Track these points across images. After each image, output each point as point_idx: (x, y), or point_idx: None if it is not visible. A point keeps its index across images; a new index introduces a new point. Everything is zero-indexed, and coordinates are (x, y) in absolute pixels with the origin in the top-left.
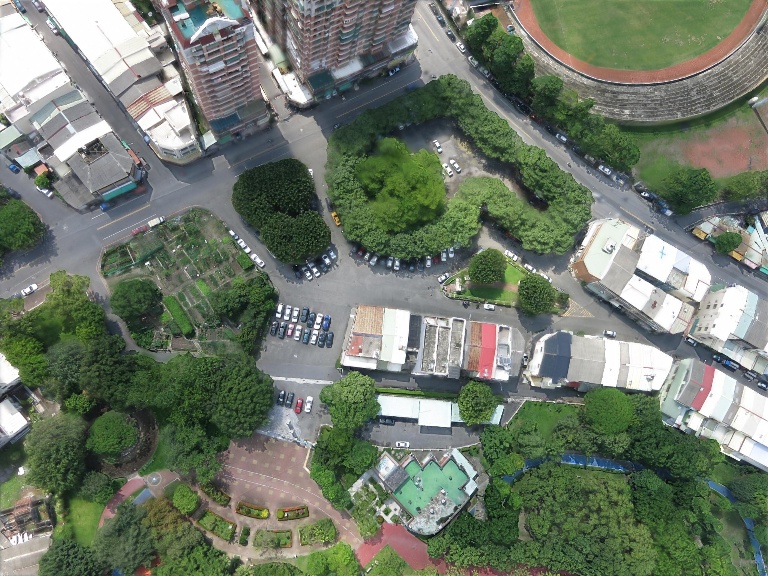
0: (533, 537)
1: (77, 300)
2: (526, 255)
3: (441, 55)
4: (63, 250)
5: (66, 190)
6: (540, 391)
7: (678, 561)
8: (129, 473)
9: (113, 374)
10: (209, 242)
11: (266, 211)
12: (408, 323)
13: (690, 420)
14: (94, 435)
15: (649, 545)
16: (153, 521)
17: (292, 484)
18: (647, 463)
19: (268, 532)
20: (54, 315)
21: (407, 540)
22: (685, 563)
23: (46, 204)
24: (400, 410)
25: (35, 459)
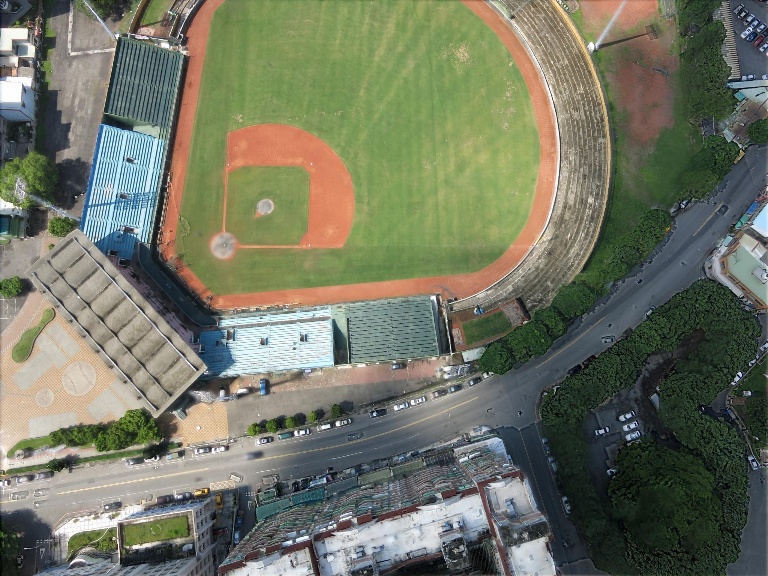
0: None
1: None
2: None
3: (495, 399)
4: None
5: None
6: None
7: None
8: None
9: None
10: None
11: None
12: None
13: None
14: None
15: None
16: None
17: None
18: None
19: None
20: None
21: None
22: None
23: None
24: None
25: None
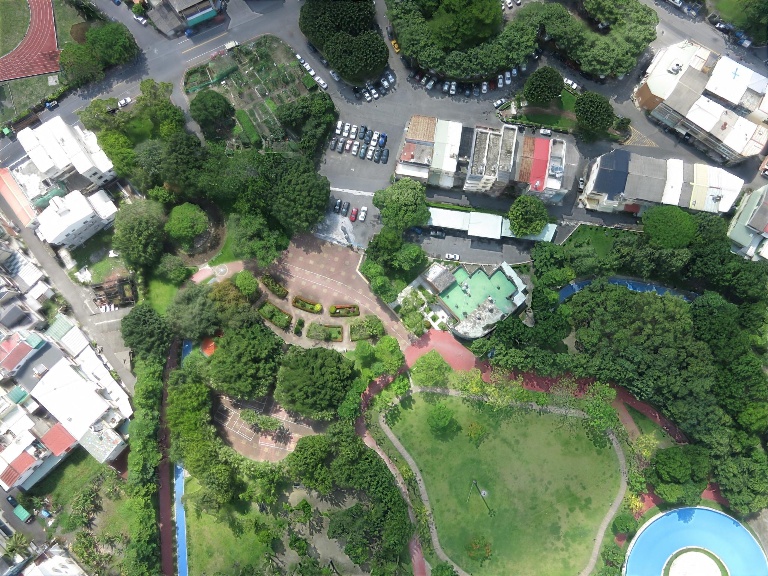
0: (582, 350)
1: (162, 102)
2: (586, 84)
3: None
4: (153, 70)
5: (157, 17)
6: (596, 216)
7: (741, 376)
8: (200, 263)
9: (189, 163)
10: (278, 66)
11: (329, 29)
12: (460, 133)
13: (763, 248)
14: (171, 220)
15: (709, 362)
16: (218, 295)
17: (345, 285)
18: (710, 283)
19: (321, 326)
20: (143, 116)
21: (453, 347)
22: (749, 380)
23: (141, 31)
24: (450, 222)
25: (121, 229)
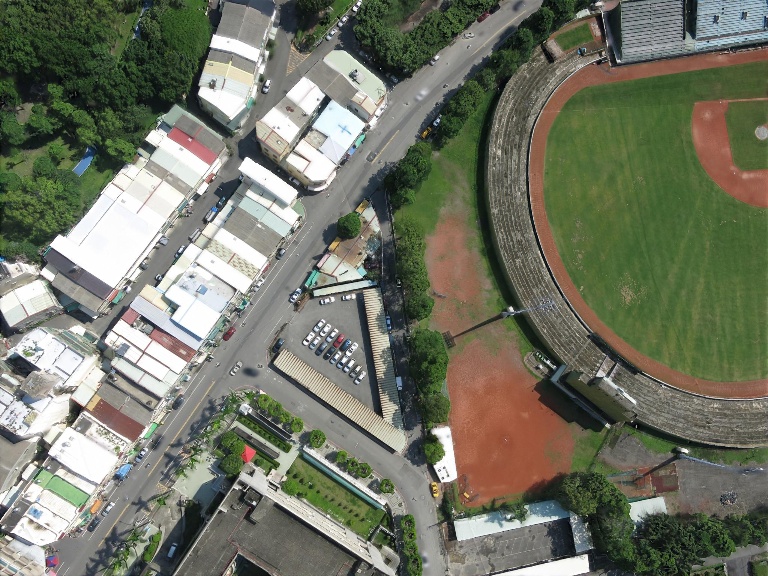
0: None
1: None
2: None
3: None
4: None
5: None
6: None
7: None
8: None
9: None
10: None
11: None
12: None
13: None
14: None
15: None
16: None
17: None
18: None
19: None
20: None
21: None
22: (6, 53)
23: None
24: None
25: None
